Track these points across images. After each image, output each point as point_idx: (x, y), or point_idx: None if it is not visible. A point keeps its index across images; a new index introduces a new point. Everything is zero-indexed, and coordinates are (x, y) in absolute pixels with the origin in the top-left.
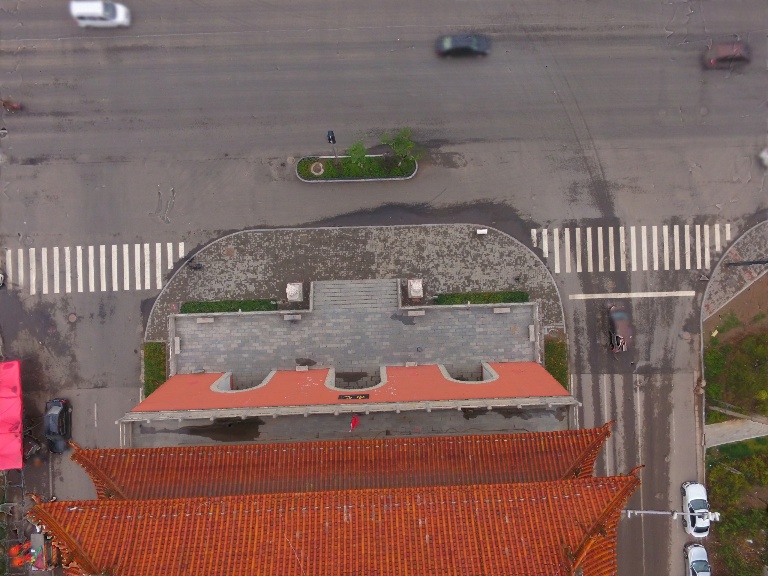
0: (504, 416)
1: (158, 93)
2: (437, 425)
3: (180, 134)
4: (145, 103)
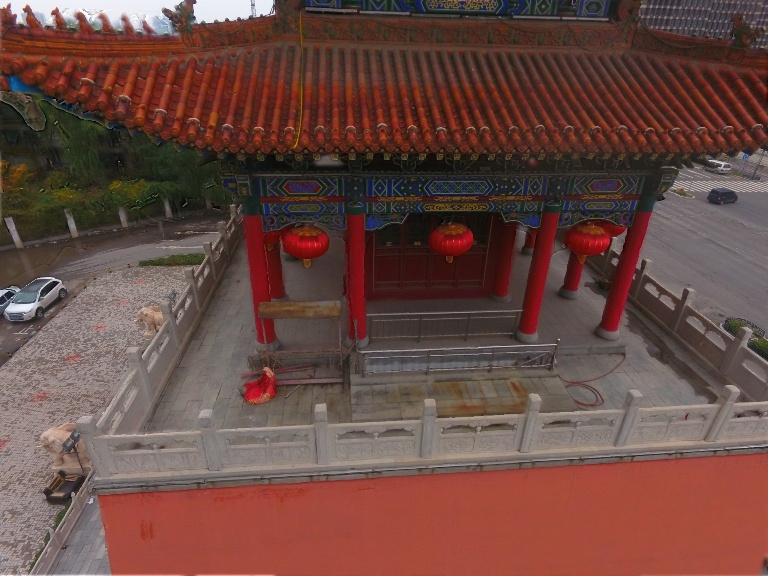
0: (629, 324)
1: (702, 256)
2: (552, 261)
3: (679, 265)
4: (686, 251)
